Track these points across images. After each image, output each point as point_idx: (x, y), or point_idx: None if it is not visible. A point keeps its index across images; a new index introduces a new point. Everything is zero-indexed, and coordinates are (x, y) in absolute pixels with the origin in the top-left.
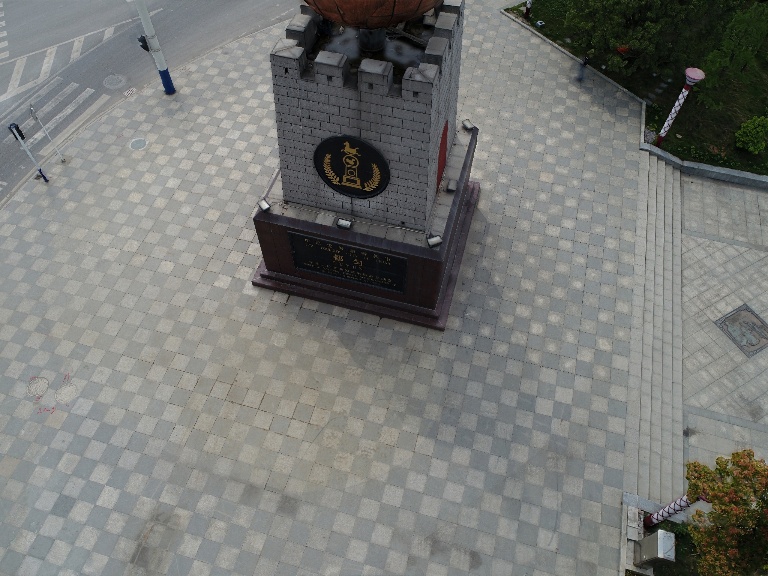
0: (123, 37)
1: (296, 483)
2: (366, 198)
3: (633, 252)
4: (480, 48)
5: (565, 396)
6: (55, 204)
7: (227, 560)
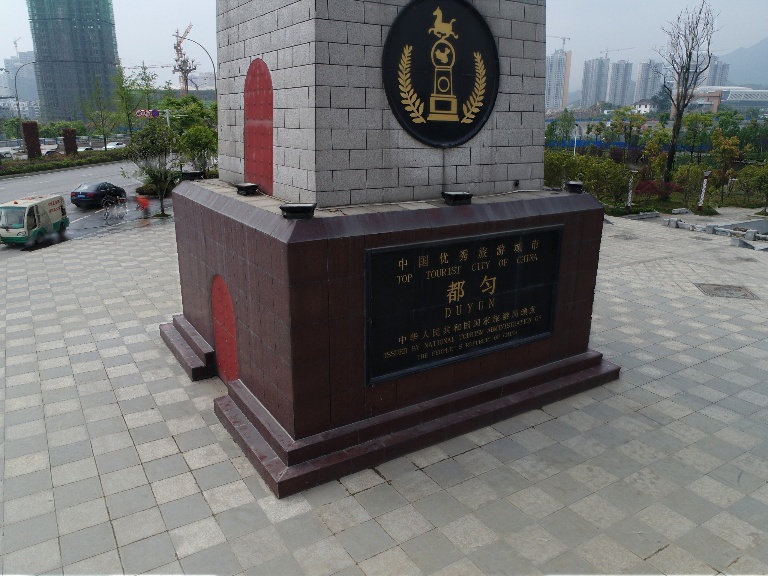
0: None
1: None
2: (466, 141)
3: (600, 274)
4: None
5: None
6: None
7: None
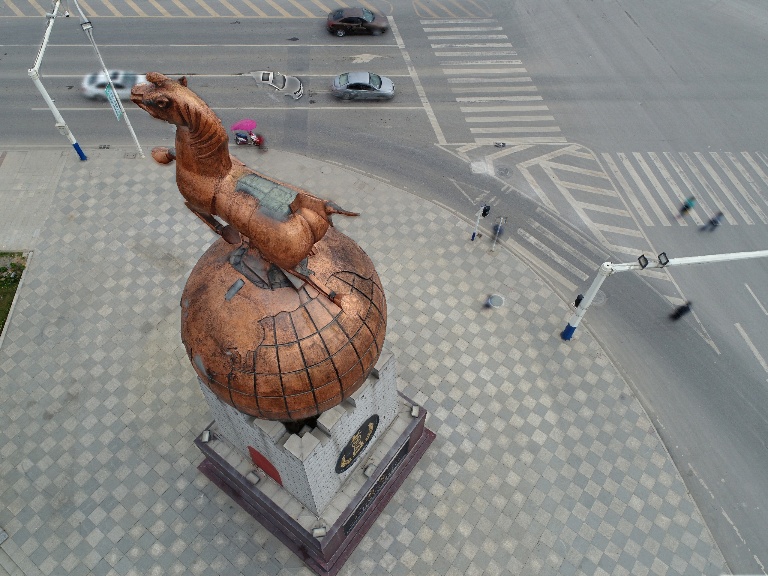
0: (668, 312)
1: (156, 336)
2: None
3: None
4: None
5: (94, 537)
6: (446, 242)
7: (139, 293)
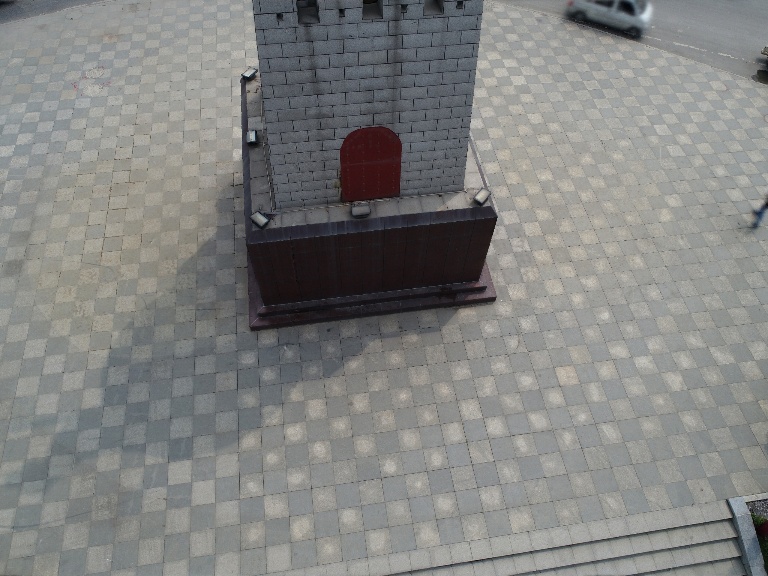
0: None
1: (36, 265)
2: None
3: (492, 535)
4: (764, 224)
5: (202, 494)
6: None
7: None
